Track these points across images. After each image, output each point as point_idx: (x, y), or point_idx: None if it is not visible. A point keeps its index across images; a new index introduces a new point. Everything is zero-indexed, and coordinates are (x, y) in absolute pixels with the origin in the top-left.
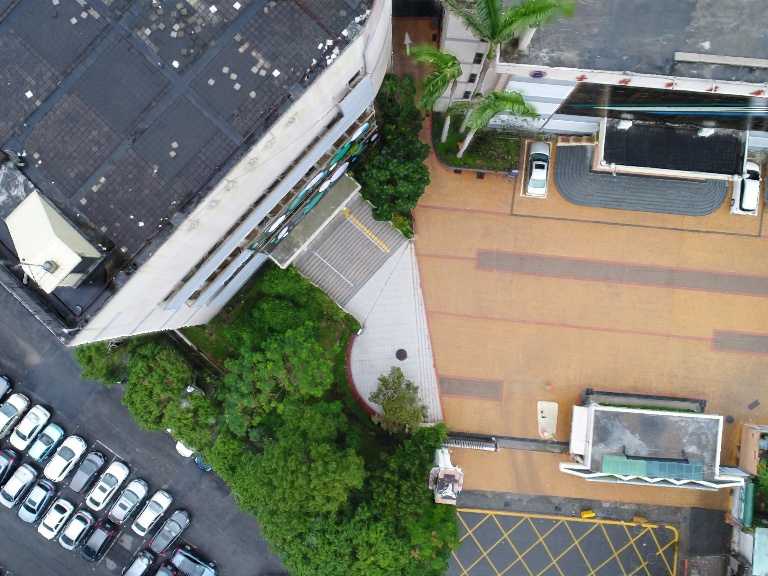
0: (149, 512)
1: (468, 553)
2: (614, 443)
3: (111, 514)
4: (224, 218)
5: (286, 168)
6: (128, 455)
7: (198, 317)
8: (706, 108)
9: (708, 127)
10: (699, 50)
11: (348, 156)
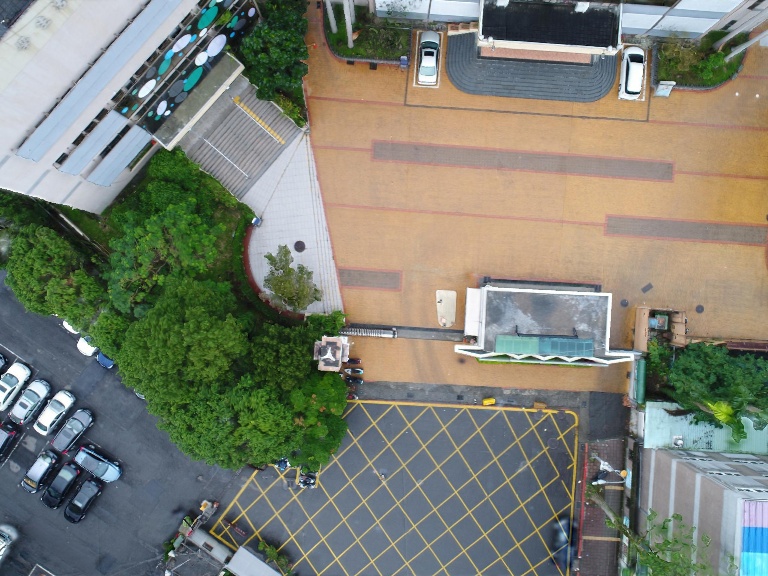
0: (50, 410)
1: (373, 444)
2: (507, 323)
3: (12, 414)
4: (68, 53)
5: (137, 12)
6: (30, 356)
7: (82, 198)
8: None
9: (583, 1)
10: None
11: (222, 26)
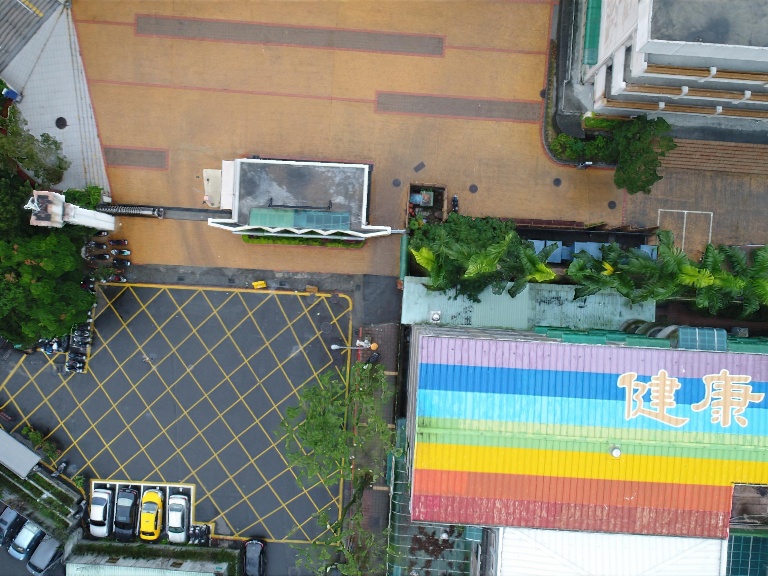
0: None
1: (142, 328)
2: (262, 196)
3: None
4: None
5: None
6: None
7: None
8: None
9: None
10: None
11: None
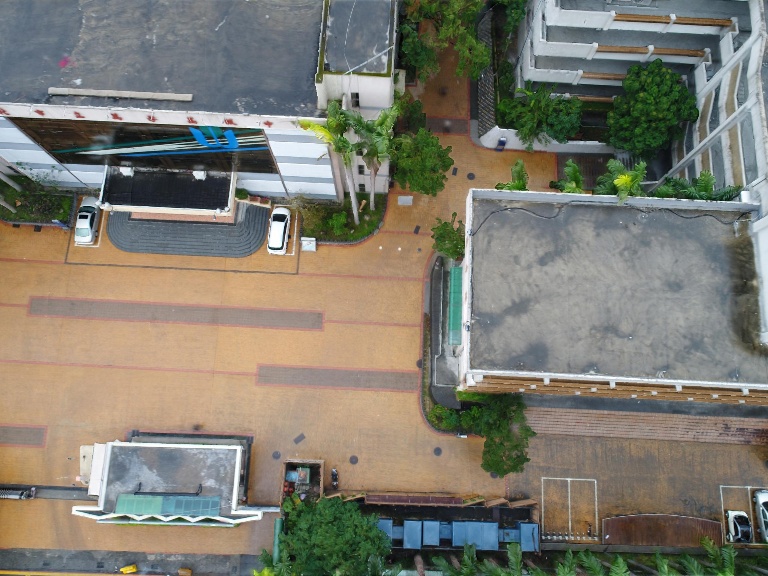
0: None
1: None
2: (131, 480)
3: None
4: None
5: None
6: None
7: None
8: (155, 147)
9: (198, 170)
10: (71, 86)
11: None
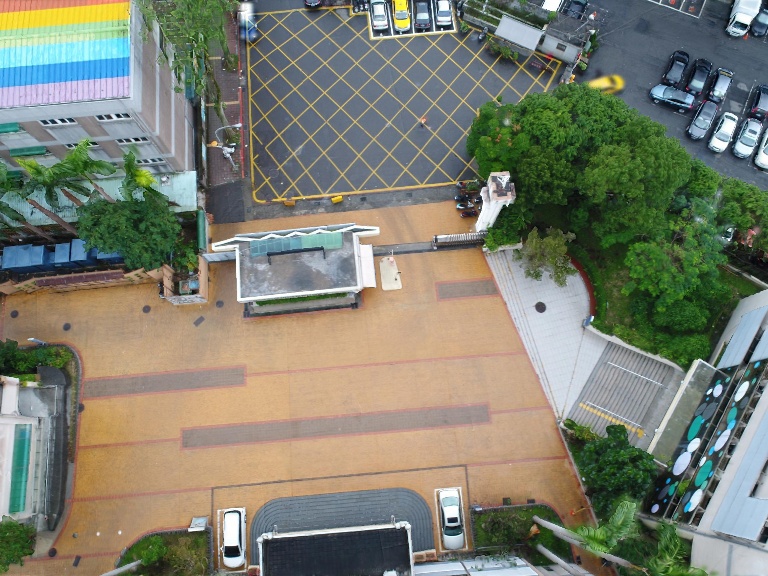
0: (728, 132)
1: (436, 150)
2: (334, 260)
3: (760, 124)
4: None
5: None
6: (760, 176)
7: (765, 298)
8: None
9: None
10: None
11: (684, 479)
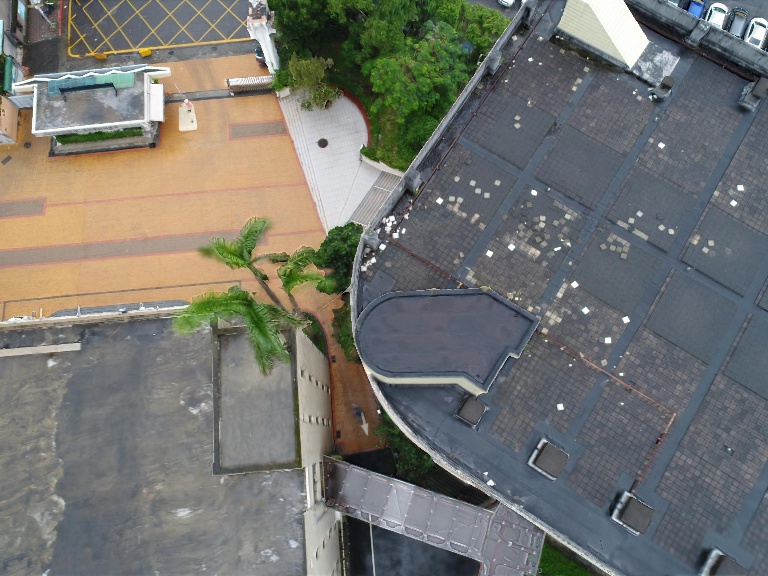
0: None
1: (243, 8)
2: (126, 97)
3: None
4: None
5: None
6: None
7: None
8: None
9: None
10: (58, 357)
11: None
